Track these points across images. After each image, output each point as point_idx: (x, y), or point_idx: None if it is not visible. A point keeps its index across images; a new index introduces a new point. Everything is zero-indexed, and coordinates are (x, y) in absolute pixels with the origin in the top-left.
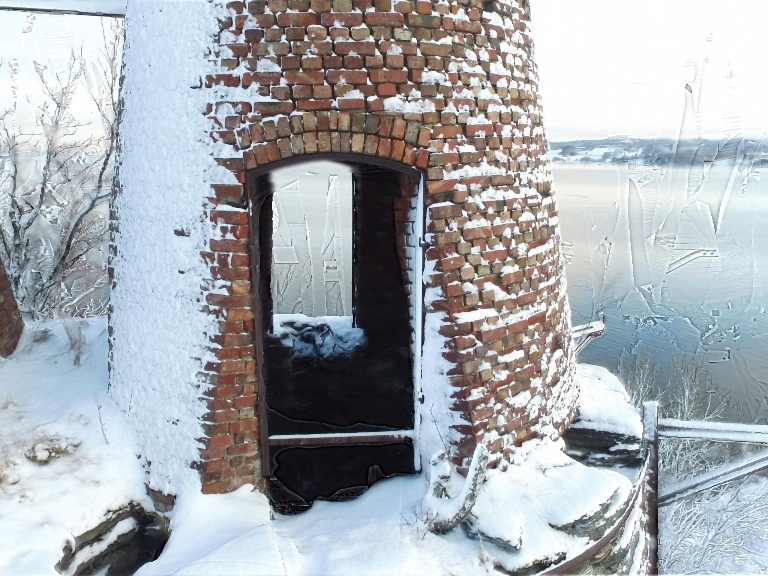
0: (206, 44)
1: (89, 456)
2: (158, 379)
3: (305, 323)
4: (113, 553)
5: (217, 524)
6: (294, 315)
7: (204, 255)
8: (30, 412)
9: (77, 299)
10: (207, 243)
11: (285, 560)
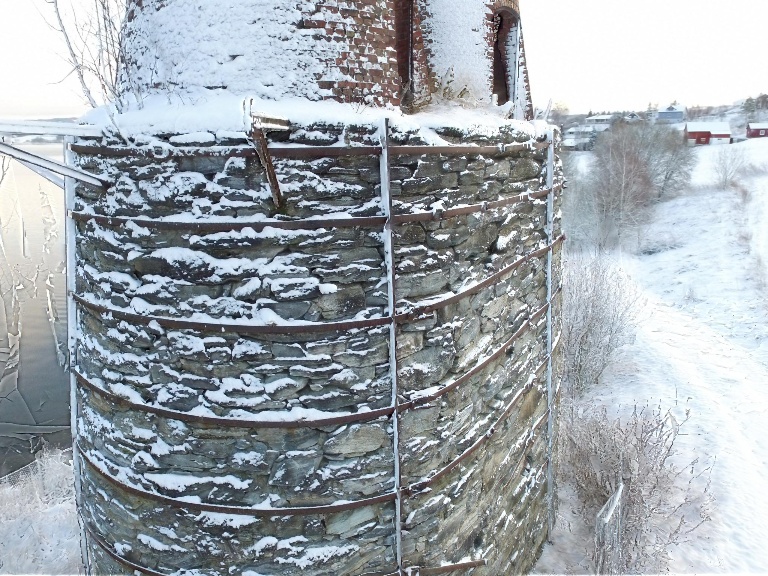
0: None
1: None
2: (472, 85)
3: None
4: None
5: None
6: None
7: (485, 38)
8: None
9: None
10: (486, 34)
11: None
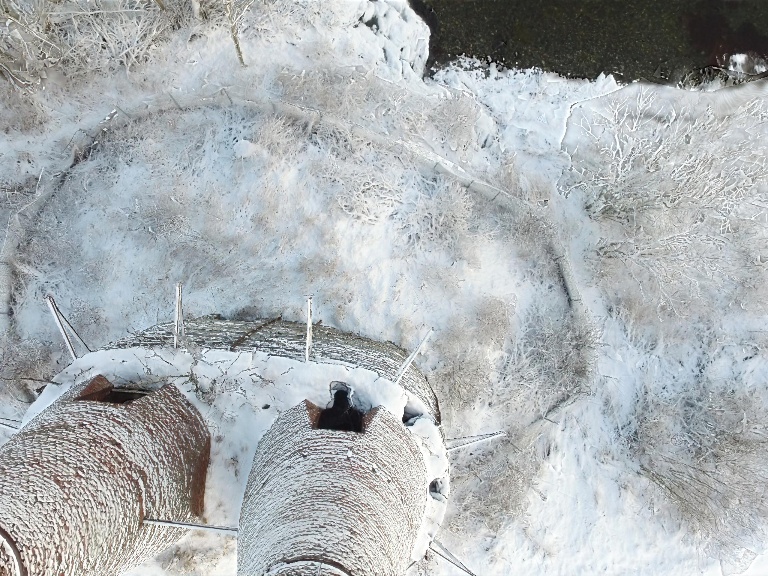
0: None
1: None
2: None
3: (345, 382)
4: None
5: None
6: (340, 374)
7: None
8: (228, 512)
9: None
10: None
11: None
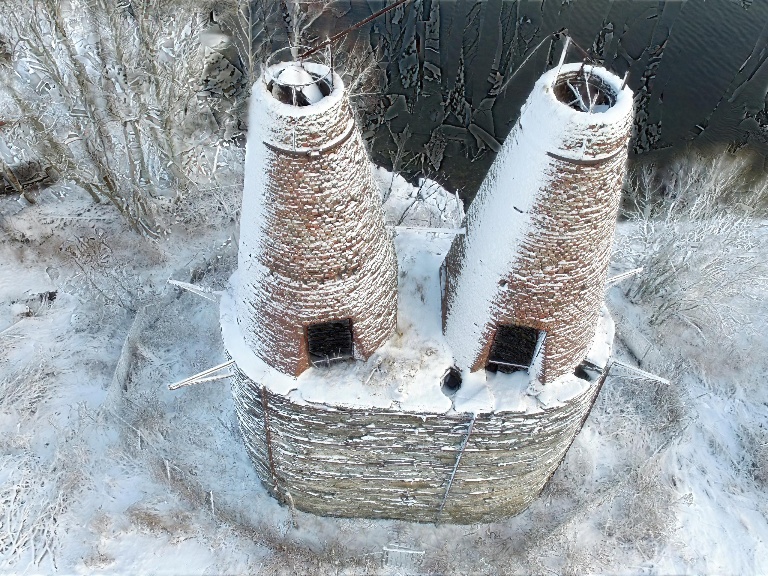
0: (494, 295)
1: (441, 355)
2: None
3: None
4: (445, 376)
5: (474, 382)
6: None
7: (482, 333)
8: (419, 331)
9: (311, 22)
10: (484, 332)
11: (492, 400)
